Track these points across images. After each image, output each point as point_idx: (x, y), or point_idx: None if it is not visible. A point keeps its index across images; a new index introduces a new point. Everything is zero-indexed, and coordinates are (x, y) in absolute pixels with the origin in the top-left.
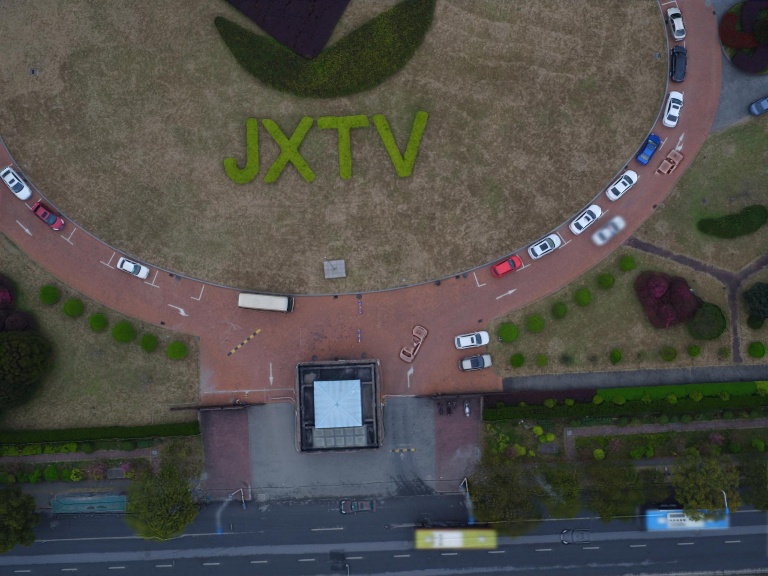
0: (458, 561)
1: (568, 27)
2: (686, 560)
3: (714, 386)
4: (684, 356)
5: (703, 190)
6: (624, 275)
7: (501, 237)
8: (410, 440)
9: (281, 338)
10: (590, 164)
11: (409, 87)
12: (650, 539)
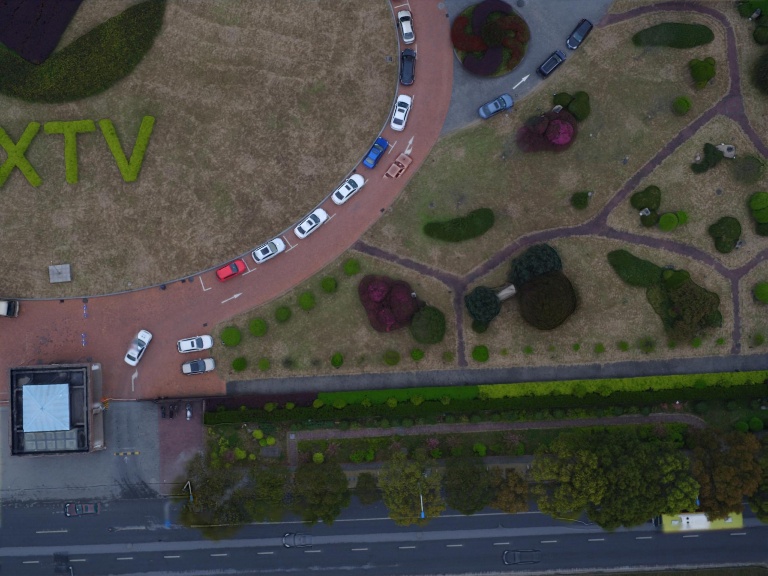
0: (180, 564)
1: (299, 31)
2: (407, 564)
3: (436, 390)
4: (409, 360)
5: (431, 194)
6: (349, 279)
7: (227, 241)
8: (134, 443)
9: (7, 342)
10: (318, 168)
11: (137, 92)
12: (371, 543)
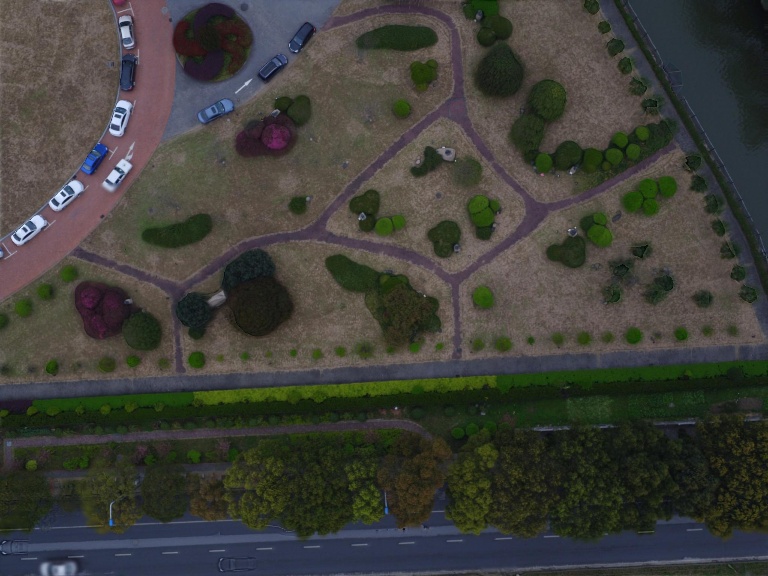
0: None
1: (21, 37)
2: (123, 571)
3: (151, 397)
4: (126, 367)
5: (151, 199)
6: (67, 286)
7: None
8: None
9: None
10: (38, 174)
11: None
12: (87, 550)
